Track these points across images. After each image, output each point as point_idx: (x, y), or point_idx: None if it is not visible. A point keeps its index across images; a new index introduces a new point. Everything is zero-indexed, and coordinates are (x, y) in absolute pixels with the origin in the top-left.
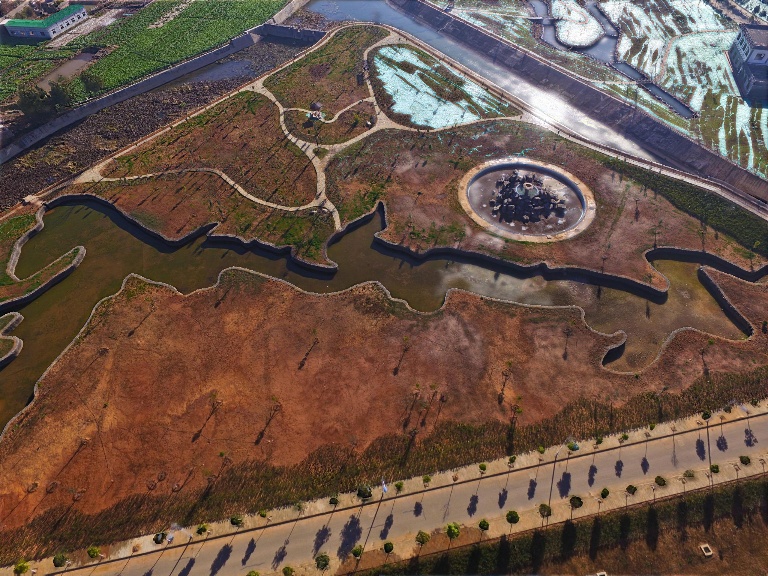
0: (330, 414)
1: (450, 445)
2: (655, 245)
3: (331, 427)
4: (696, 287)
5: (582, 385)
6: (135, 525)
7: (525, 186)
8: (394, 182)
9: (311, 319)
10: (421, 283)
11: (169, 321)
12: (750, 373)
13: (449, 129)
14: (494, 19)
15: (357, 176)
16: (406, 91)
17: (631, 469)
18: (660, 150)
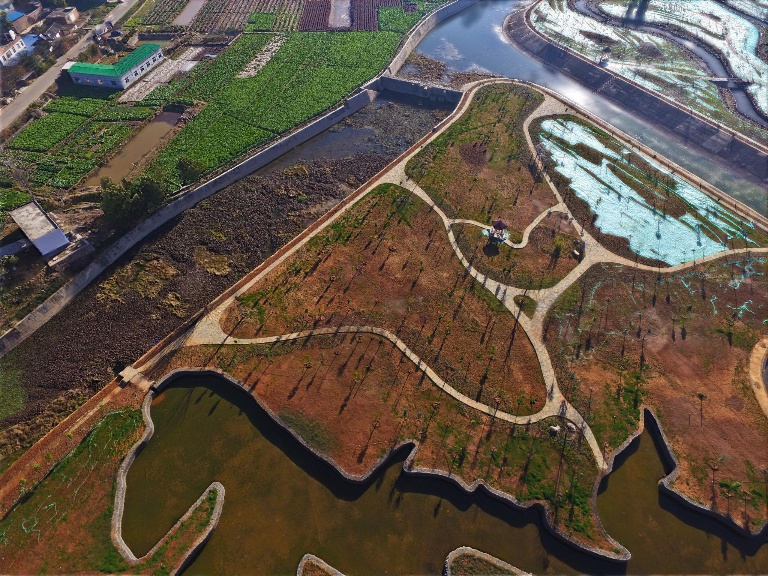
0: None
1: None
2: None
3: None
4: None
5: None
6: None
7: None
8: (653, 370)
9: None
10: None
11: None
12: None
13: (691, 267)
14: (667, 80)
15: (594, 354)
16: (603, 195)
17: None
18: None
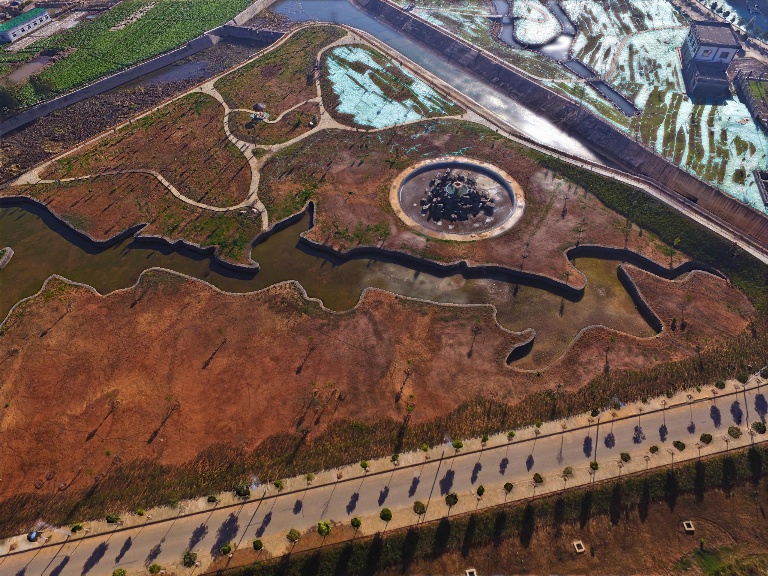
0: (226, 413)
1: (340, 443)
2: (578, 243)
3: (225, 426)
4: (614, 285)
5: (481, 383)
6: (16, 524)
7: (454, 185)
8: (327, 182)
9: (223, 319)
10: (340, 282)
11: (83, 321)
12: (649, 370)
13: (390, 128)
14: (453, 18)
15: (291, 176)
16: (354, 91)
17: (515, 466)
18: (601, 148)
